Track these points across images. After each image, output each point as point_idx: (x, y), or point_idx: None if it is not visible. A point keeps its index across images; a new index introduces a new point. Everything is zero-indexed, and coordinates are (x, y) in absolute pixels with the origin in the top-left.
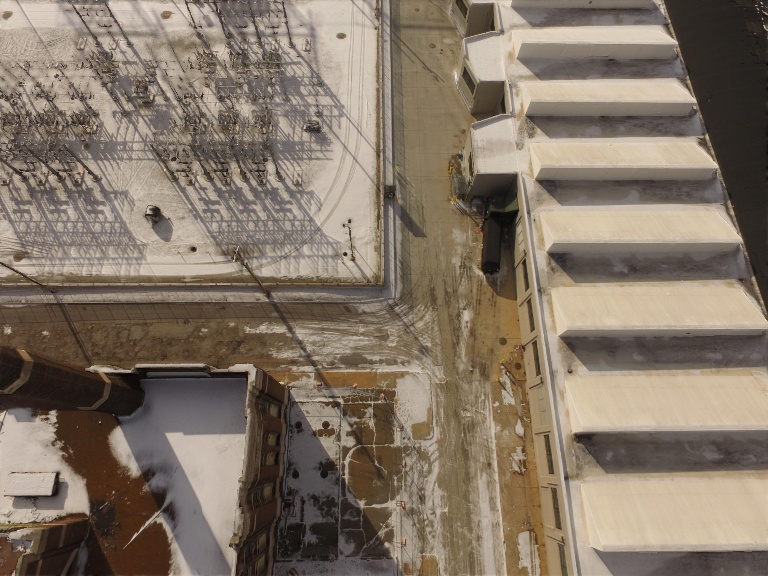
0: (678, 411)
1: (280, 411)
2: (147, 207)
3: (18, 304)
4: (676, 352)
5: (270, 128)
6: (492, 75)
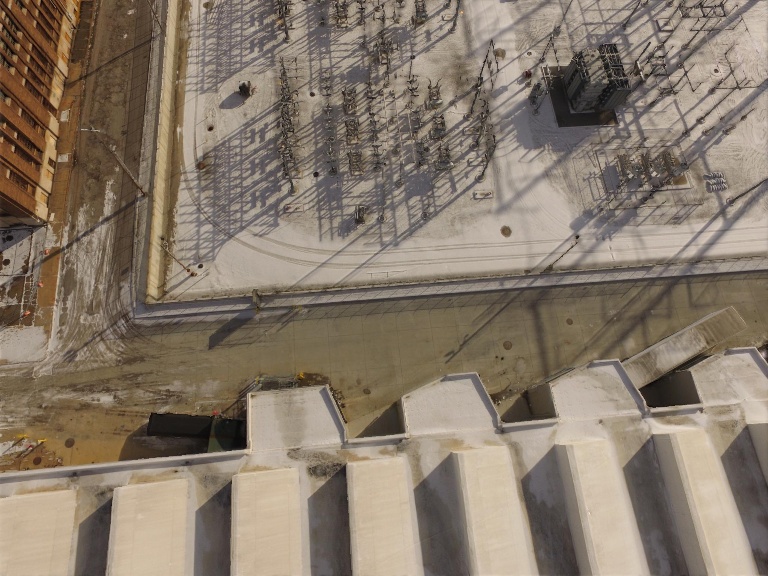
0: None
1: (7, 215)
2: None
3: None
4: None
5: (356, 173)
6: (417, 415)
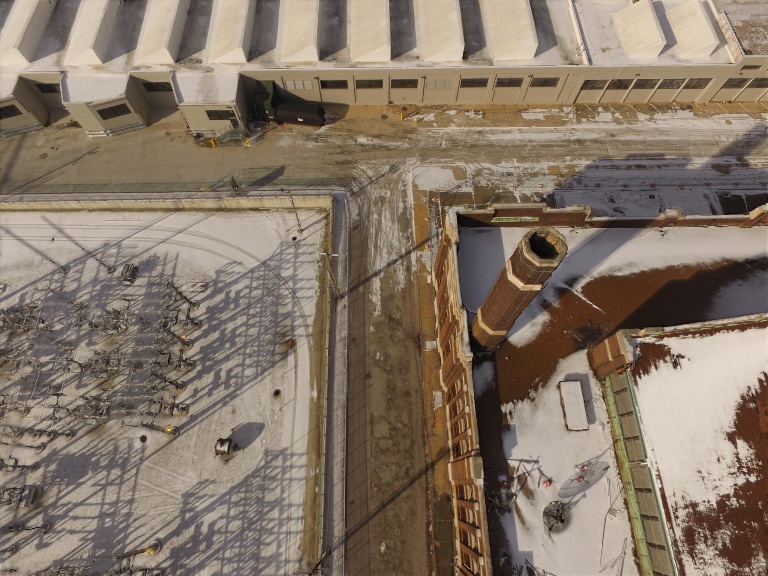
0: (445, 1)
1: None
2: (218, 451)
3: None
4: (401, 2)
5: None
6: (118, 85)
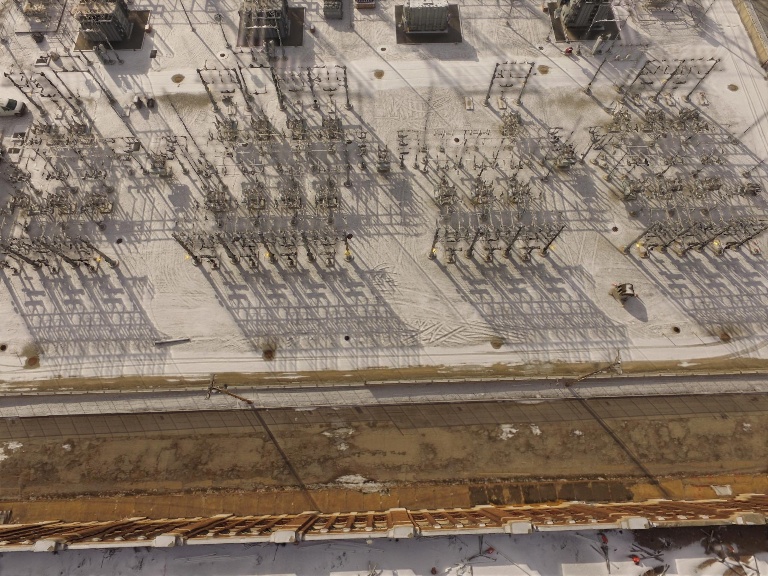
0: None
1: None
2: (626, 286)
3: (535, 400)
4: None
5: None
6: None
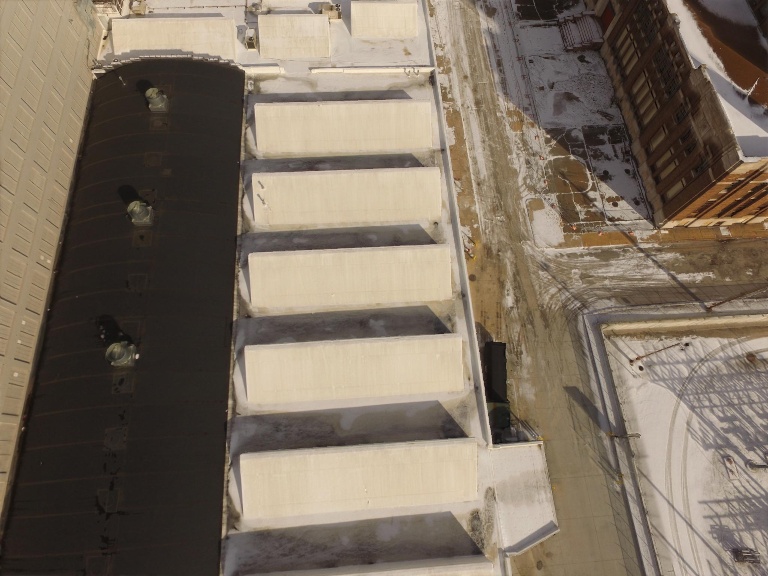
0: (354, 187)
1: (664, 201)
2: None
3: None
4: (336, 243)
5: None
6: None
